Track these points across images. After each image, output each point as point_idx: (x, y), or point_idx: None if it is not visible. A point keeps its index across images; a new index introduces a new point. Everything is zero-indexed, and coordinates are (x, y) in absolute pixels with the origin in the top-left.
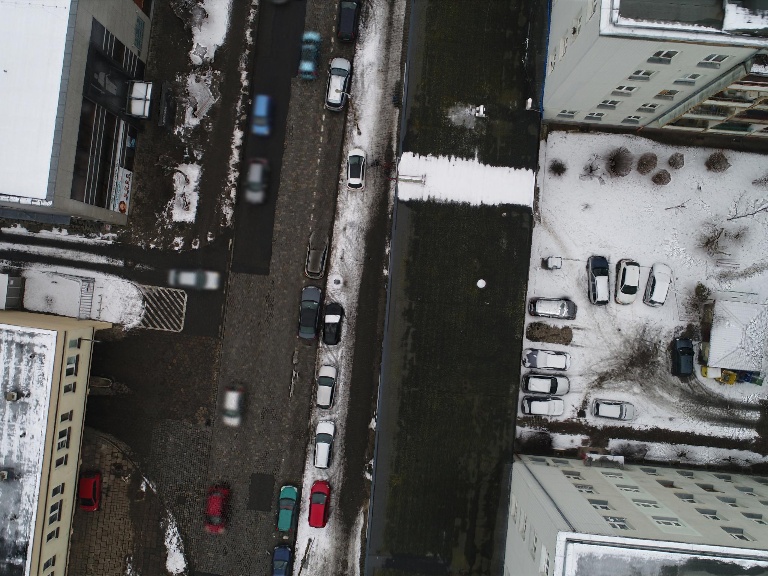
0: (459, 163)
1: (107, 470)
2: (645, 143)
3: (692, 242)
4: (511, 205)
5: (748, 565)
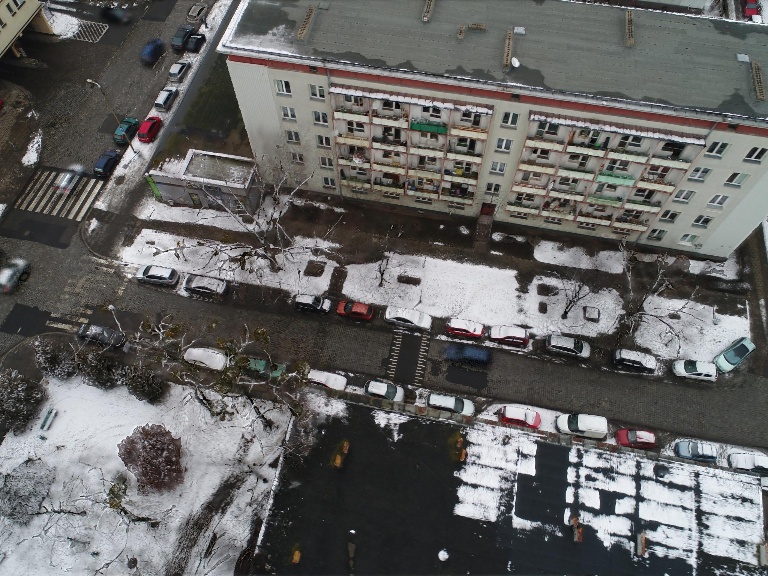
0: None
1: (9, 104)
2: None
3: None
4: None
5: None
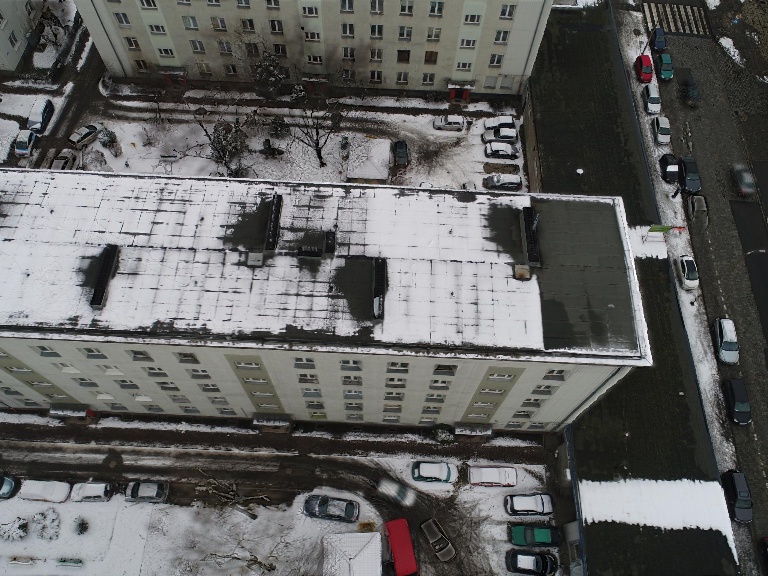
0: None
1: None
2: None
3: None
4: None
5: None
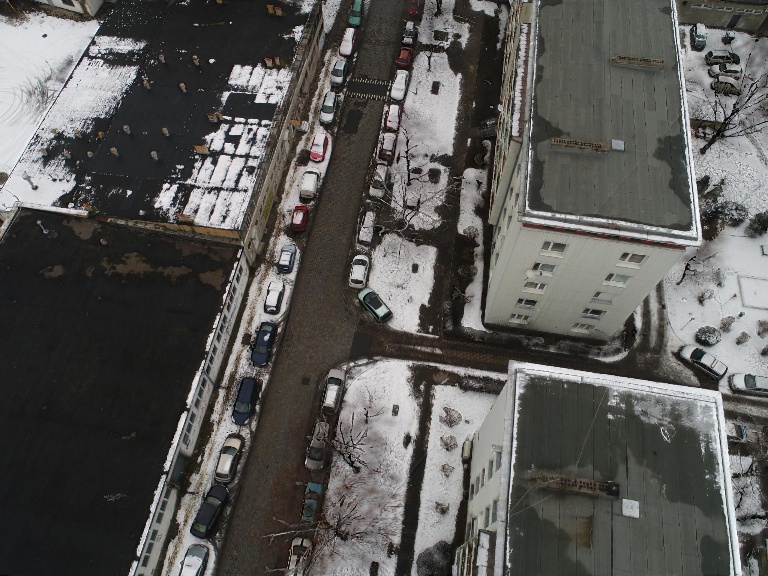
0: None
1: None
2: None
3: None
4: None
5: None
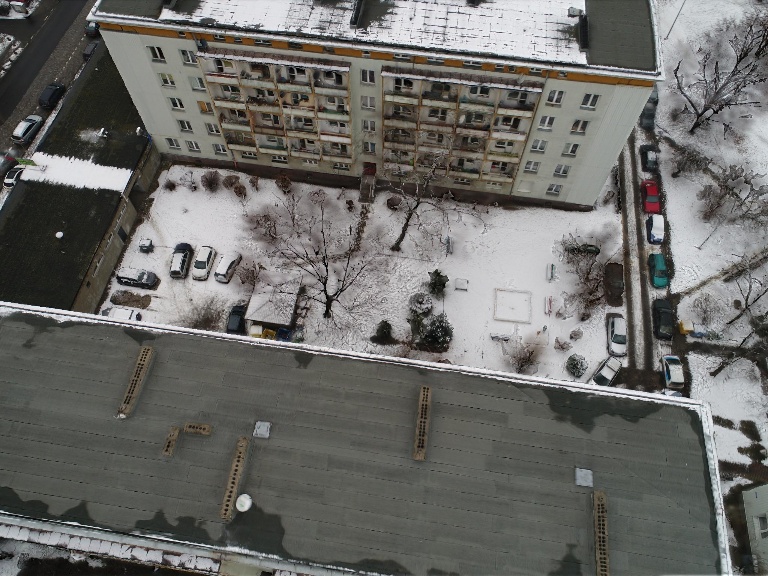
0: (76, 162)
1: None
2: (241, 175)
3: (263, 239)
4: (107, 190)
5: (63, 320)
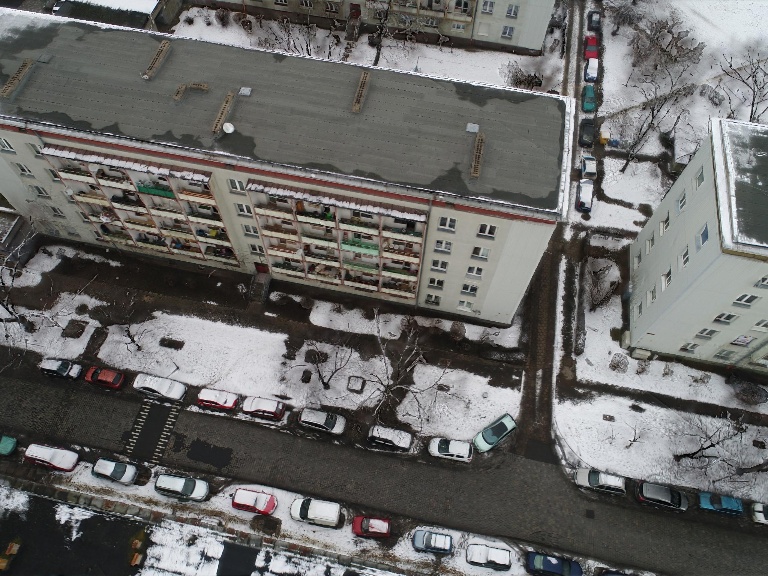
0: None
1: None
2: (248, 17)
3: None
4: (137, 12)
5: (105, 27)
